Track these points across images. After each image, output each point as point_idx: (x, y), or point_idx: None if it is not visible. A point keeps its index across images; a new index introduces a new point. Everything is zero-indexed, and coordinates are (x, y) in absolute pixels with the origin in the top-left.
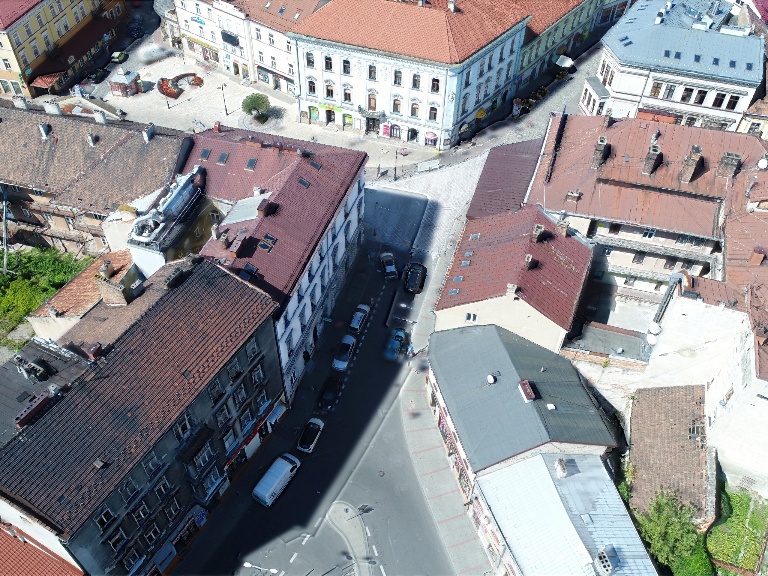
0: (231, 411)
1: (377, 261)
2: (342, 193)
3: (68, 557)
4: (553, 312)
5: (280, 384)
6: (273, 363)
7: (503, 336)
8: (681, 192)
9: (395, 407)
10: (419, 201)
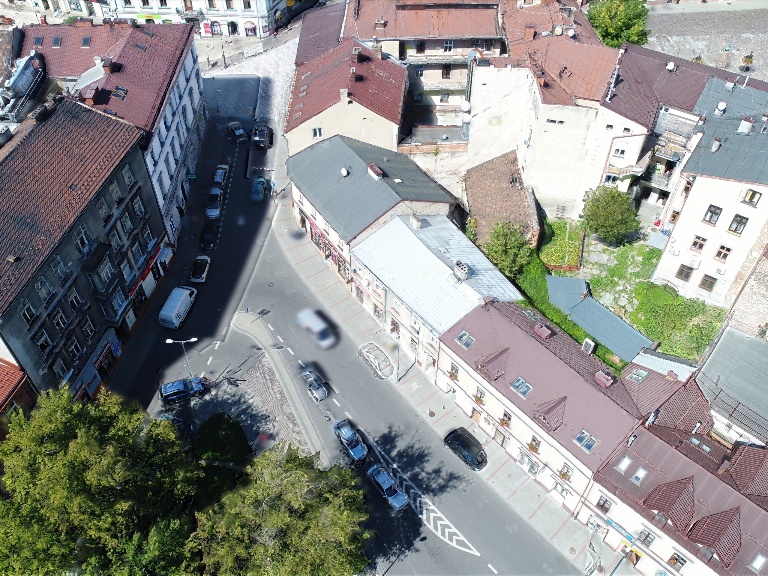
0: (122, 238)
1: (226, 131)
2: (178, 55)
3: (2, 349)
4: (383, 111)
5: (161, 225)
6: (150, 199)
7: (347, 142)
8: (465, 5)
9: (271, 235)
10: (252, 80)
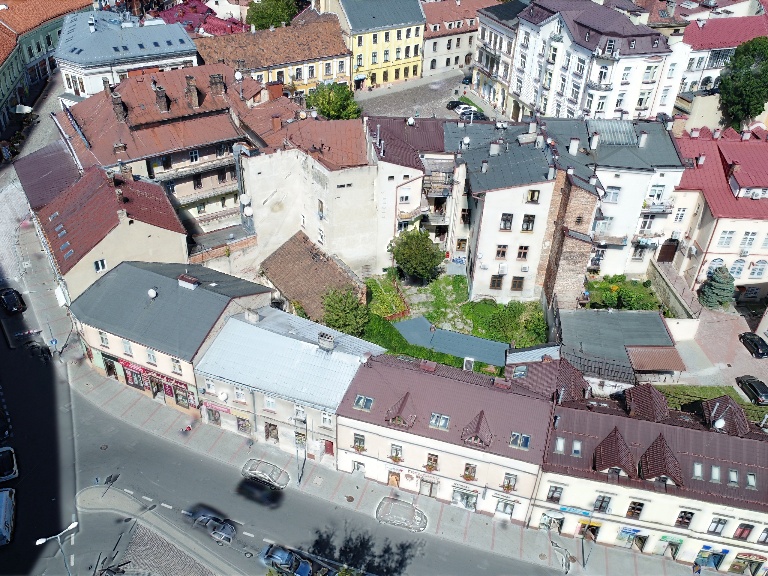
0: None
1: None
2: None
3: None
4: (166, 225)
5: None
6: None
7: (137, 266)
8: (198, 114)
9: (75, 397)
10: None
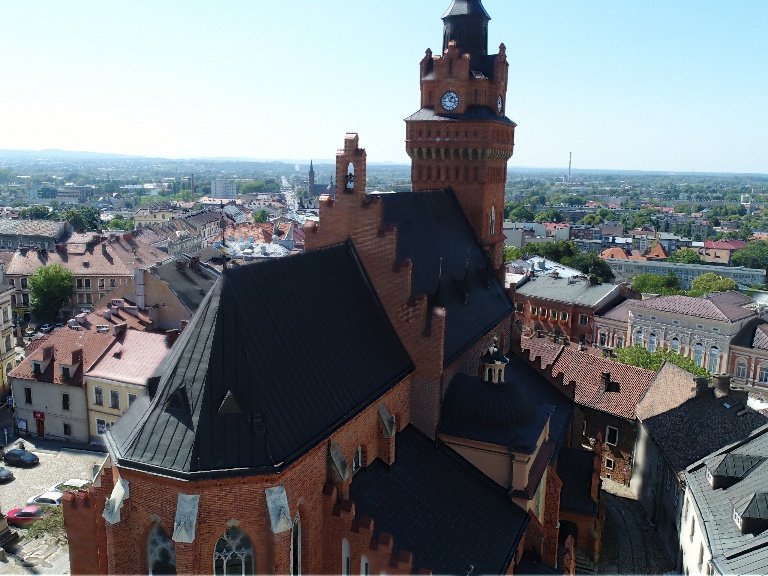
0: None
1: None
2: None
3: None
4: None
5: None
6: None
7: None
8: None
9: None
10: None
